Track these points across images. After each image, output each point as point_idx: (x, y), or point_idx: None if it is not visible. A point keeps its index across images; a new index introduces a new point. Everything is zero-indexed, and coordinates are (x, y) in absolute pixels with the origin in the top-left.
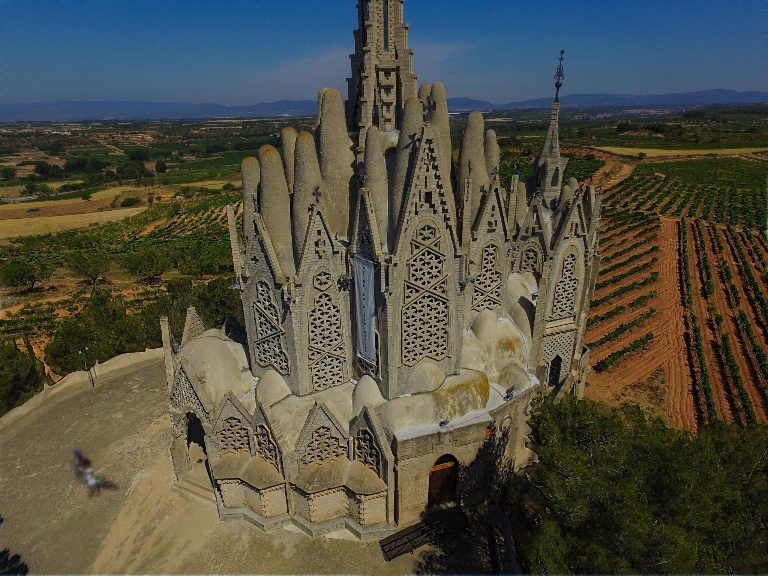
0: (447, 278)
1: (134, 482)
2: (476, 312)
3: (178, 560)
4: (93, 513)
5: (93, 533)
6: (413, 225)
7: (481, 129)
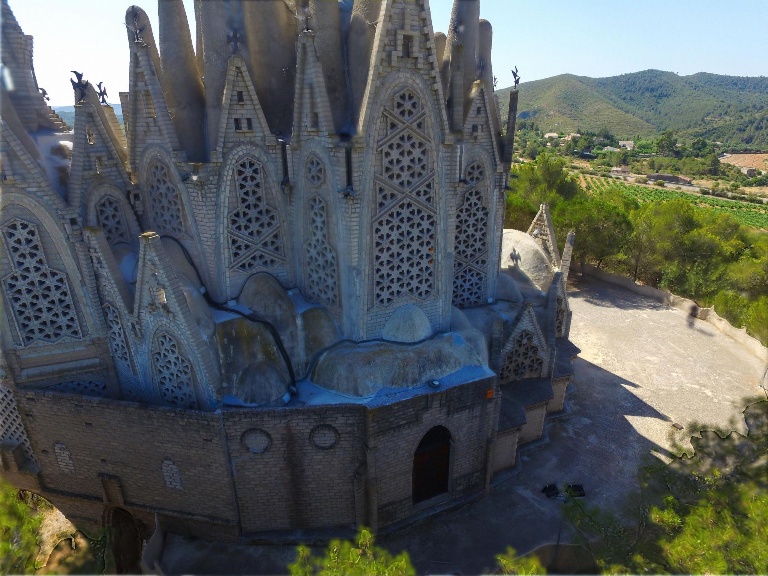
0: None
1: None
2: None
3: None
4: None
5: None
6: None
7: None
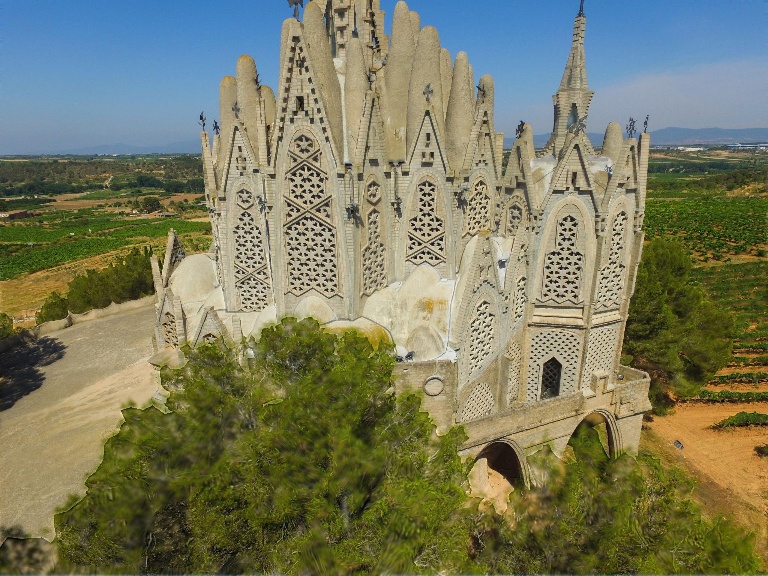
0: (330, 200)
1: (138, 361)
2: (413, 265)
3: (103, 415)
4: (99, 370)
5: (87, 381)
6: (289, 134)
7: (431, 46)
